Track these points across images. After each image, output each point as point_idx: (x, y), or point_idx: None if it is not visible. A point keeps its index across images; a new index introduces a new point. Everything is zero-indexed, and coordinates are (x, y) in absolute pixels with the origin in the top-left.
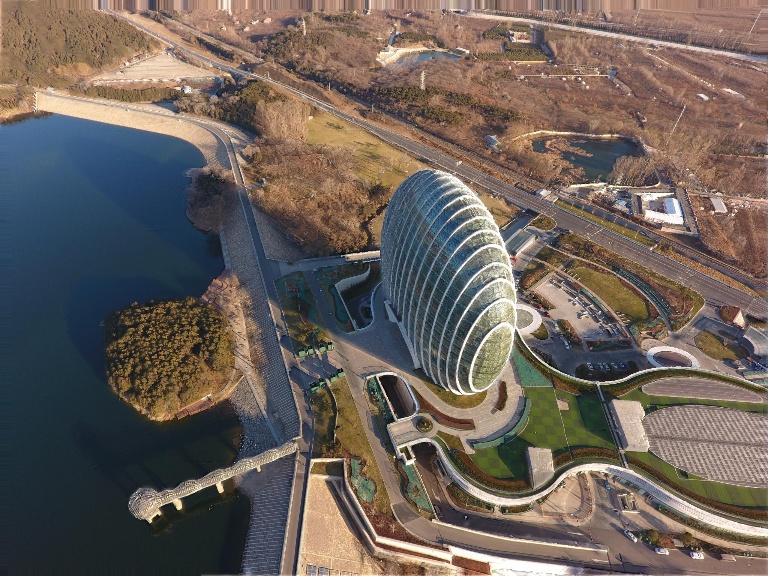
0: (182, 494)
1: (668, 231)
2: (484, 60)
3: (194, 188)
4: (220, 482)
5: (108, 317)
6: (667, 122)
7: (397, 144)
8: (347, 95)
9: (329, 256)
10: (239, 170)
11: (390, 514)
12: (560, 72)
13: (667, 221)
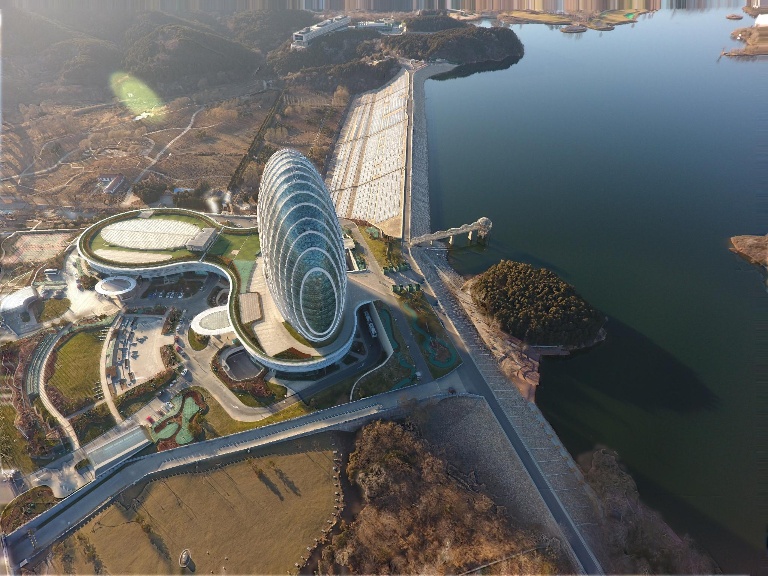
0: None
1: None
2: None
3: None
4: None
5: None
6: None
7: None
8: None
9: None
10: None
11: None
12: None
13: None
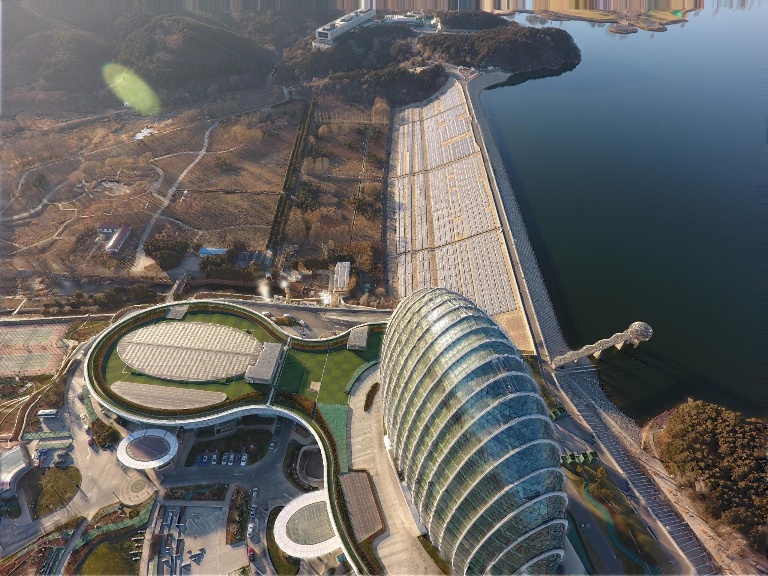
0: None
1: None
2: None
3: None
4: None
5: None
6: None
7: None
8: None
9: None
10: None
11: None
12: None
13: None
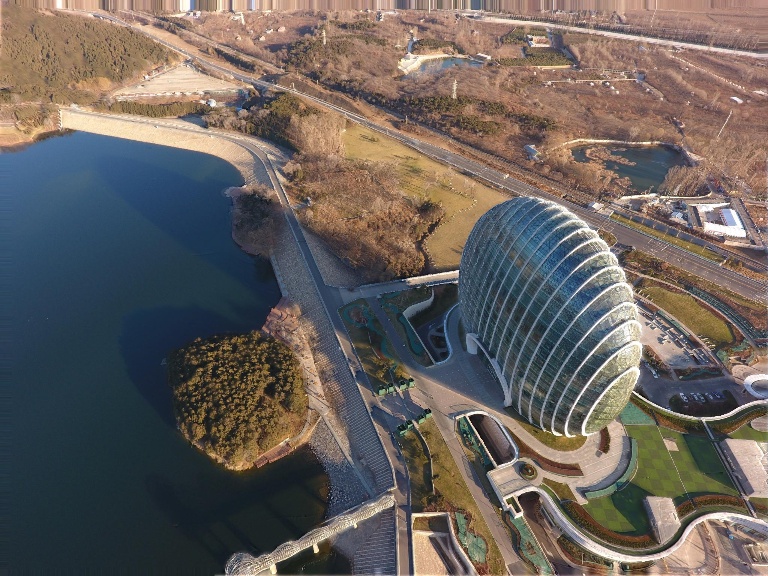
0: (280, 559)
1: (731, 244)
2: (507, 66)
3: (239, 209)
4: (317, 542)
5: (171, 355)
6: (706, 127)
7: (437, 157)
8: (376, 106)
9: (390, 281)
10: (281, 189)
11: (506, 575)
12: (587, 77)
13: (729, 234)
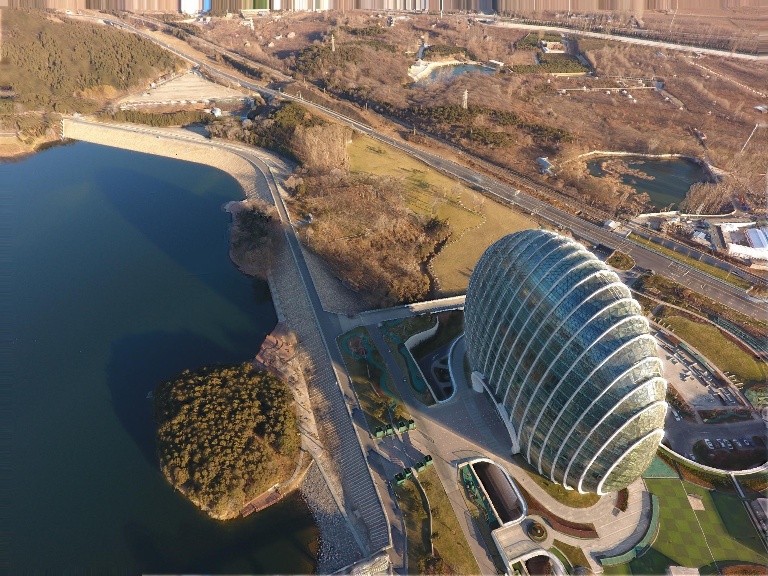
0: None
1: (758, 268)
2: (520, 73)
3: (237, 227)
4: None
5: (157, 388)
6: (729, 139)
7: (445, 170)
8: (384, 115)
9: (392, 307)
10: (282, 204)
11: None
12: (603, 85)
13: (755, 256)
